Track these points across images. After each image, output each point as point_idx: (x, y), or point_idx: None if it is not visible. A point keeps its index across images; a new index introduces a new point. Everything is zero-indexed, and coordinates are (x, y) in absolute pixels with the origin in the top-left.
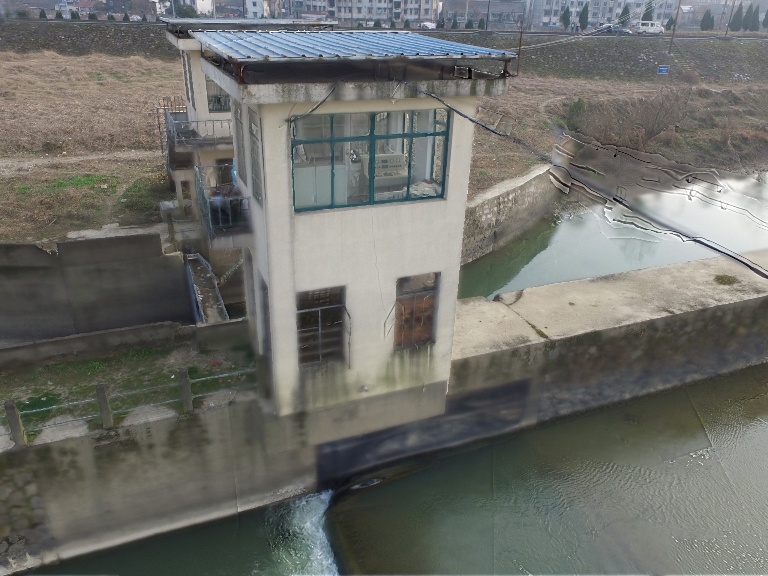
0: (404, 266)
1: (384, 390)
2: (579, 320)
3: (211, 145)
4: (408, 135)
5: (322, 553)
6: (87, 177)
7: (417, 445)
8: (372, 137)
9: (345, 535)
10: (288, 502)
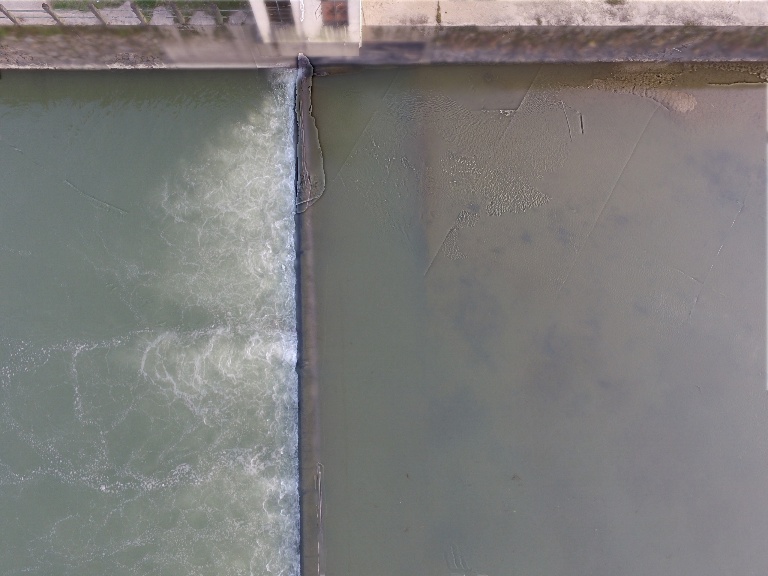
0: None
1: (320, 41)
2: (472, 11)
3: None
4: None
5: (291, 102)
6: None
7: (353, 59)
8: None
9: None
10: (283, 69)
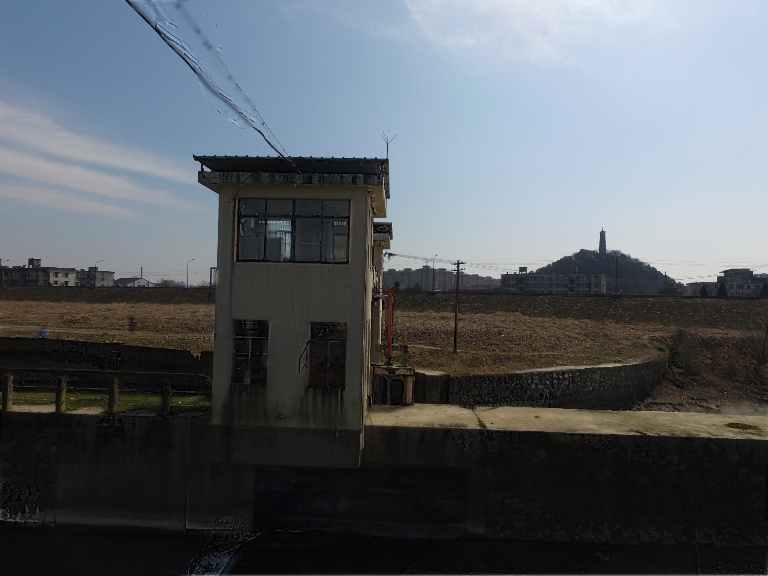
0: (315, 313)
1: (299, 424)
2: (531, 424)
3: None
4: (319, 217)
5: (215, 573)
6: None
7: (349, 511)
8: (293, 216)
9: (238, 560)
10: (227, 534)
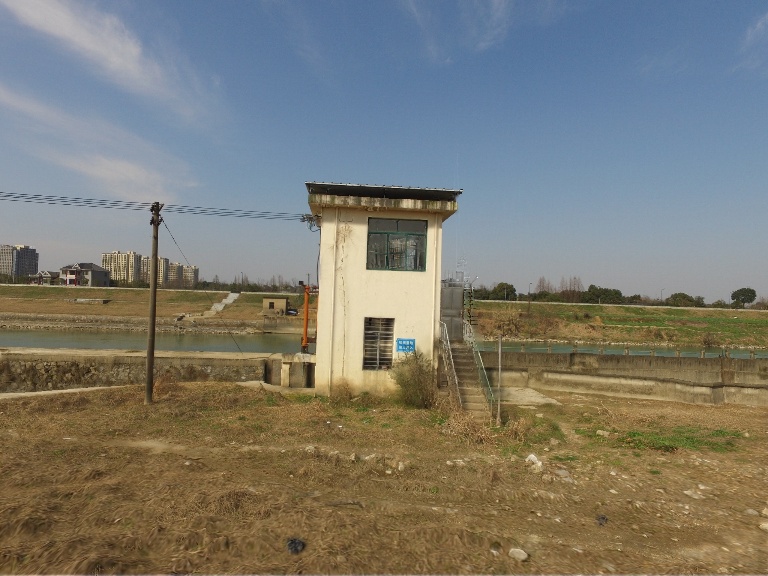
0: None
1: None
2: None
3: None
4: None
5: None
6: None
7: None
8: None
9: None
10: None
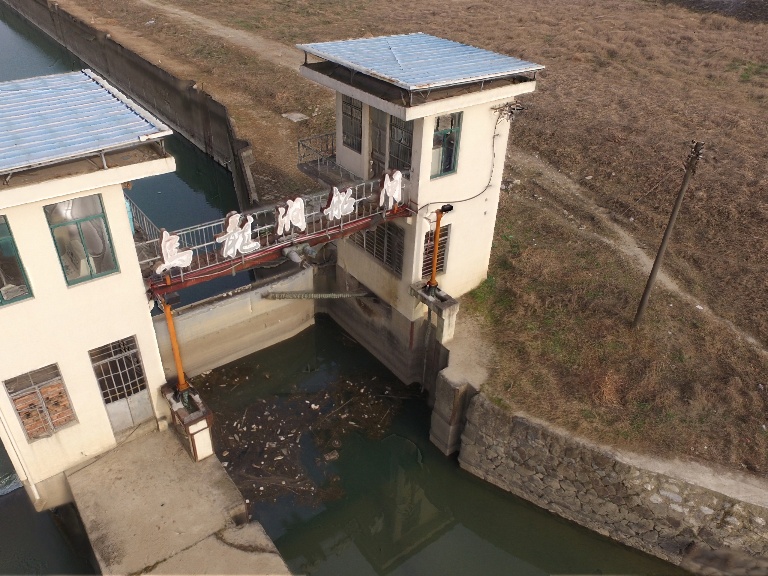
0: None
1: None
2: None
3: (316, 176)
4: None
5: None
6: None
7: None
8: None
9: None
10: None
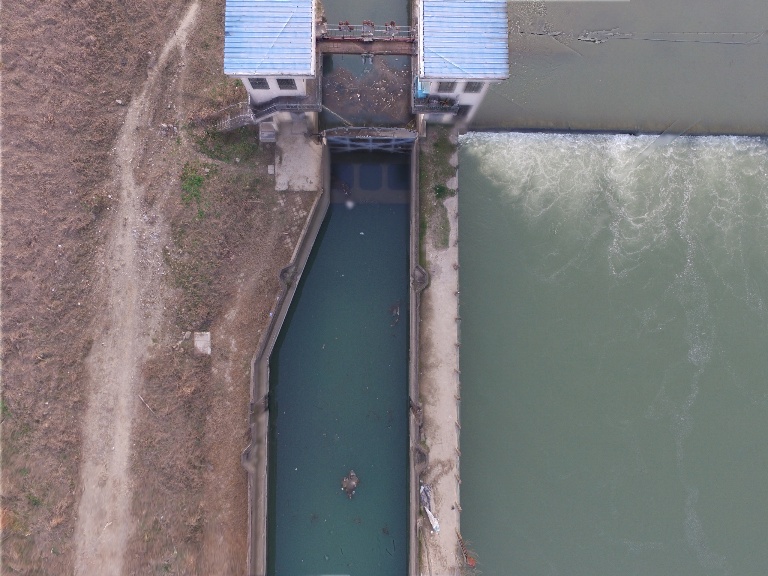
0: None
1: None
2: None
3: None
4: None
5: (471, 135)
6: (185, 180)
7: None
8: None
9: (472, 126)
10: None
